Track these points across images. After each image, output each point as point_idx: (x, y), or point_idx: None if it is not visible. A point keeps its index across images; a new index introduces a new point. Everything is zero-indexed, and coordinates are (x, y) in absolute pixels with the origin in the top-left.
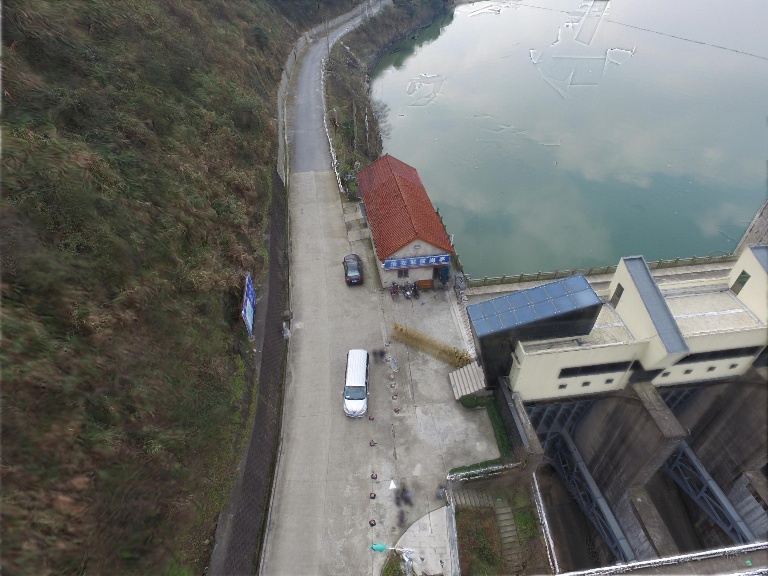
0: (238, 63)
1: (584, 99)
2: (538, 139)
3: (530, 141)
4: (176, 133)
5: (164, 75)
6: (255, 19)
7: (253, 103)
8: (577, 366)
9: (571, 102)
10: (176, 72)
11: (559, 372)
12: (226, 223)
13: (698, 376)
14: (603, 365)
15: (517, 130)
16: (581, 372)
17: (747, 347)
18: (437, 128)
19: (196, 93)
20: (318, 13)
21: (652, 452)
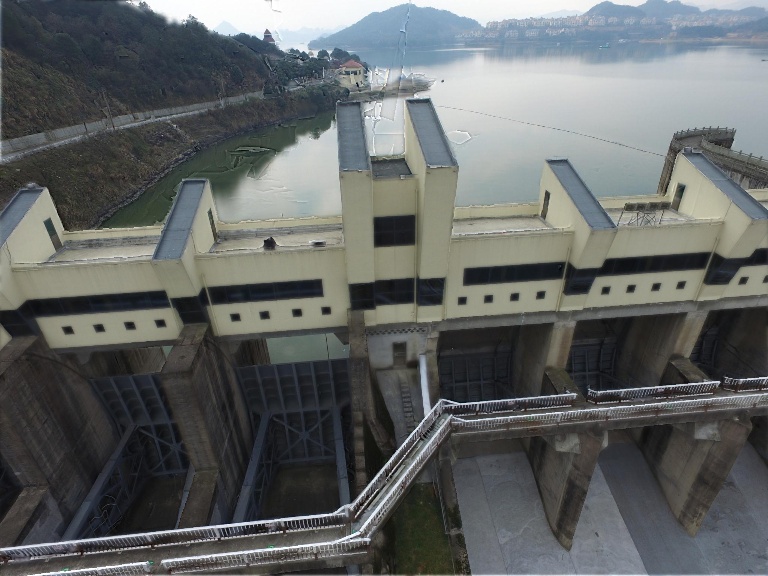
0: None
1: None
2: (296, 197)
3: (286, 199)
4: None
5: None
6: (3, 85)
7: None
8: None
9: None
10: None
11: None
12: None
13: None
14: None
15: (283, 190)
16: None
17: None
18: None
19: None
20: (166, 99)
21: None
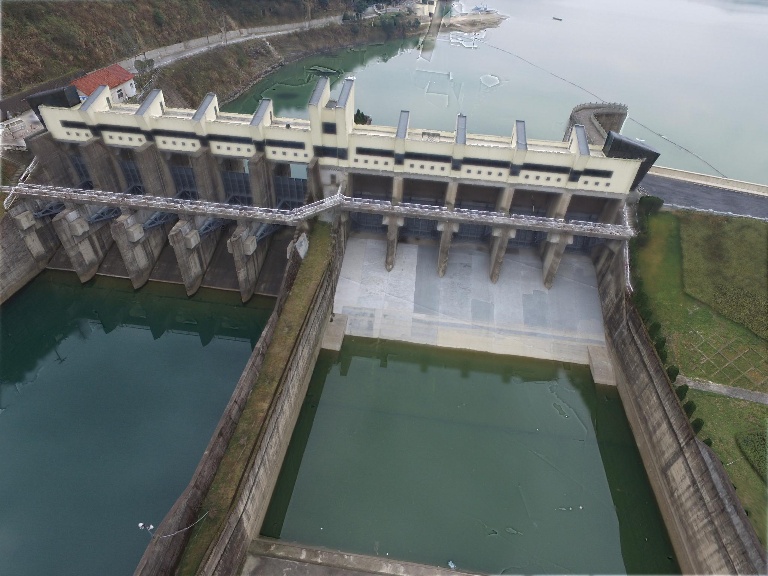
0: (104, 21)
1: (438, 105)
2: None
3: None
4: (0, 30)
5: (13, 8)
6: (162, 7)
7: (65, 31)
8: (65, 120)
9: (429, 106)
10: (28, 10)
11: (60, 122)
12: (5, 69)
13: (128, 143)
14: (77, 123)
15: None
16: (72, 126)
17: (136, 127)
18: (283, 97)
19: (37, 21)
20: (265, 19)
21: None
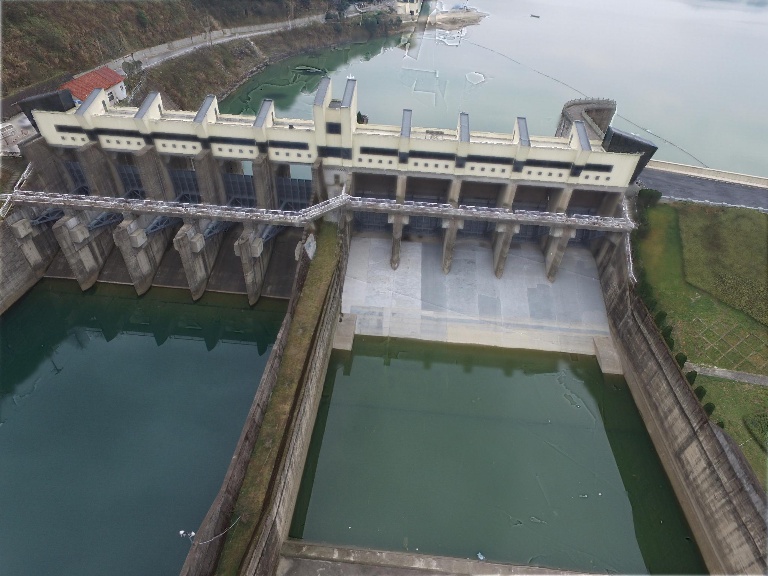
0: (88, 22)
1: (425, 103)
2: None
3: None
4: None
5: None
6: (145, 7)
7: (50, 33)
8: (60, 124)
9: (416, 104)
10: (10, 11)
11: (54, 127)
12: None
13: (126, 147)
14: (72, 127)
15: None
16: (67, 130)
17: (134, 130)
18: None
19: (20, 23)
20: (247, 18)
21: (80, 163)
